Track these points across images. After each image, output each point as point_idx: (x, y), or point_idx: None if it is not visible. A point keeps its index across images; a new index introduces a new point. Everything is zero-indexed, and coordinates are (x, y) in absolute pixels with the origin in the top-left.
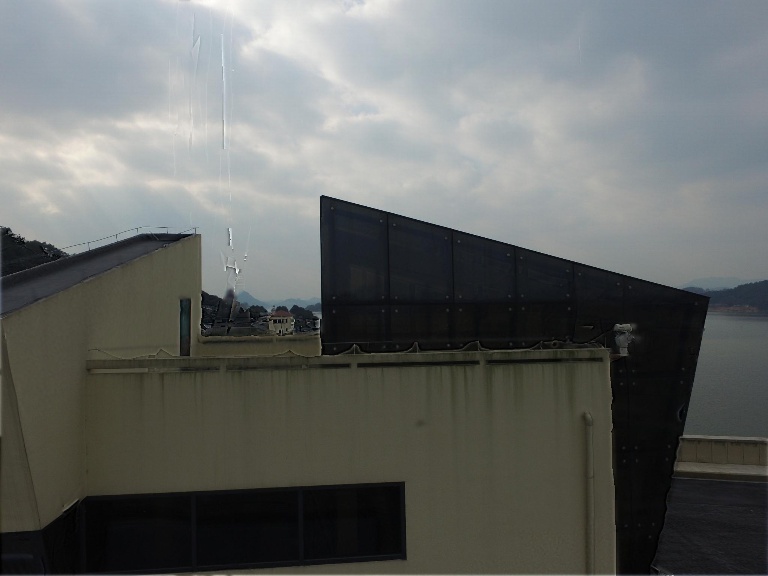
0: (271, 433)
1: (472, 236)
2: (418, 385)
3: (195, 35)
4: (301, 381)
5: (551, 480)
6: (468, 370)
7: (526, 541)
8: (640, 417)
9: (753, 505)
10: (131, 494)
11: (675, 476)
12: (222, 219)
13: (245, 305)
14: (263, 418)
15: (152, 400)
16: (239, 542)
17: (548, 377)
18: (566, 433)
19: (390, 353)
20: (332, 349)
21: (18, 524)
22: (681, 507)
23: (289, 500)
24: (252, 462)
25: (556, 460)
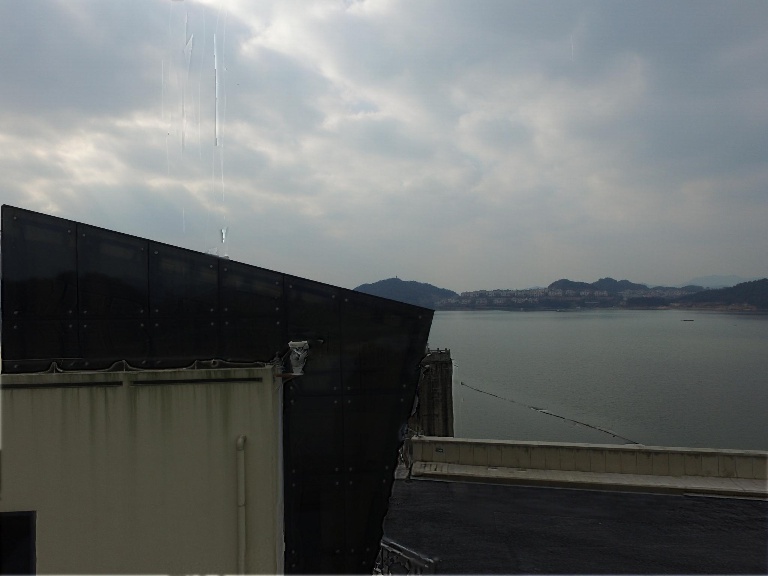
0: None
1: (171, 247)
2: (53, 408)
3: (188, 34)
4: None
5: (203, 508)
6: (109, 392)
7: (174, 573)
8: (369, 436)
9: (605, 517)
10: None
11: (546, 486)
12: (215, 218)
13: None
14: None
15: None
16: None
17: (200, 399)
18: (220, 458)
19: (25, 374)
20: (13, 367)
21: None
22: (530, 519)
23: None
24: None
25: (209, 487)
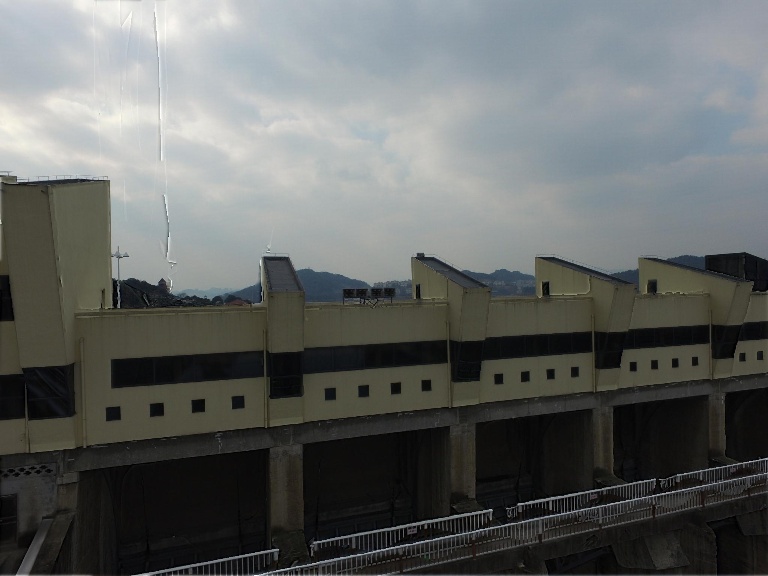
0: None
1: None
2: None
3: (122, 8)
4: (761, 298)
5: None
6: None
7: None
8: None
9: None
10: None
11: None
12: (160, 206)
13: None
14: (755, 306)
15: None
16: (749, 335)
17: None
18: None
19: None
20: None
21: None
22: None
23: (759, 325)
24: None
25: None
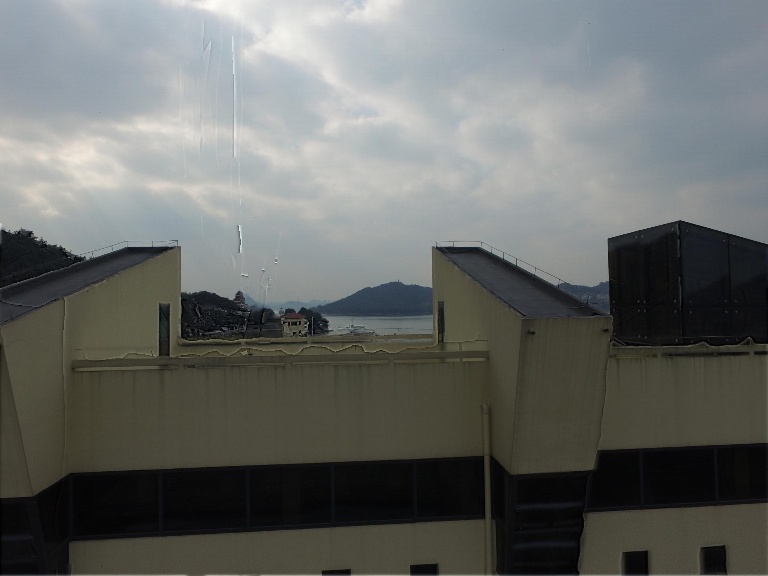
0: (693, 405)
1: None
2: None
3: (205, 39)
4: (715, 365)
5: None
6: None
7: None
8: None
9: None
10: (597, 450)
11: None
12: (233, 222)
13: (276, 307)
14: (688, 393)
15: (610, 379)
16: (669, 488)
17: None
18: None
19: None
20: (689, 342)
21: (582, 465)
22: None
23: (707, 456)
24: (680, 427)
25: None
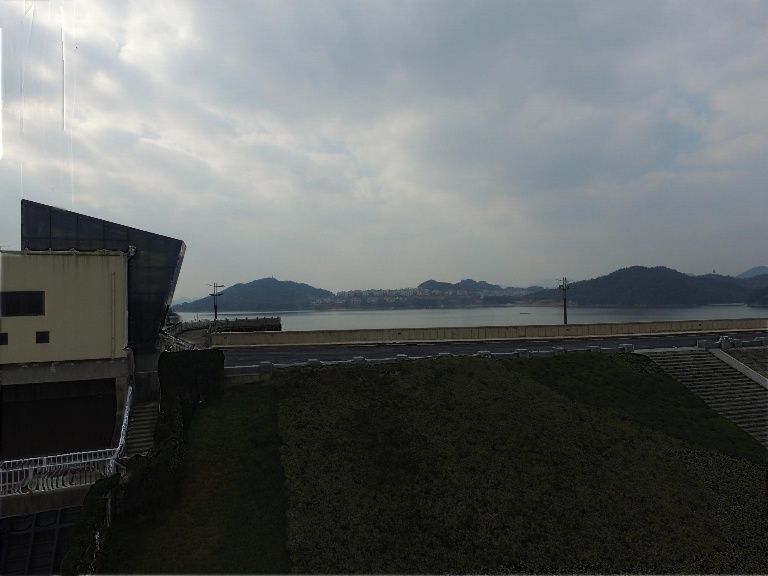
0: None
1: None
2: (50, 261)
3: (27, 2)
4: (5, 258)
5: (100, 293)
6: (69, 257)
7: (91, 311)
8: (161, 283)
9: None
10: None
11: (277, 348)
12: None
13: None
14: None
15: None
16: None
17: (99, 260)
18: (106, 278)
19: (40, 251)
20: None
21: None
22: None
23: (0, 296)
24: None
25: (102, 286)
